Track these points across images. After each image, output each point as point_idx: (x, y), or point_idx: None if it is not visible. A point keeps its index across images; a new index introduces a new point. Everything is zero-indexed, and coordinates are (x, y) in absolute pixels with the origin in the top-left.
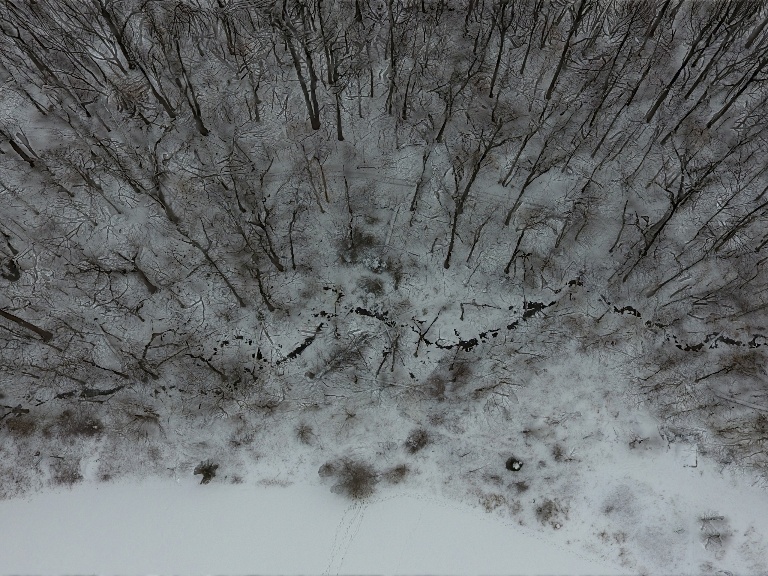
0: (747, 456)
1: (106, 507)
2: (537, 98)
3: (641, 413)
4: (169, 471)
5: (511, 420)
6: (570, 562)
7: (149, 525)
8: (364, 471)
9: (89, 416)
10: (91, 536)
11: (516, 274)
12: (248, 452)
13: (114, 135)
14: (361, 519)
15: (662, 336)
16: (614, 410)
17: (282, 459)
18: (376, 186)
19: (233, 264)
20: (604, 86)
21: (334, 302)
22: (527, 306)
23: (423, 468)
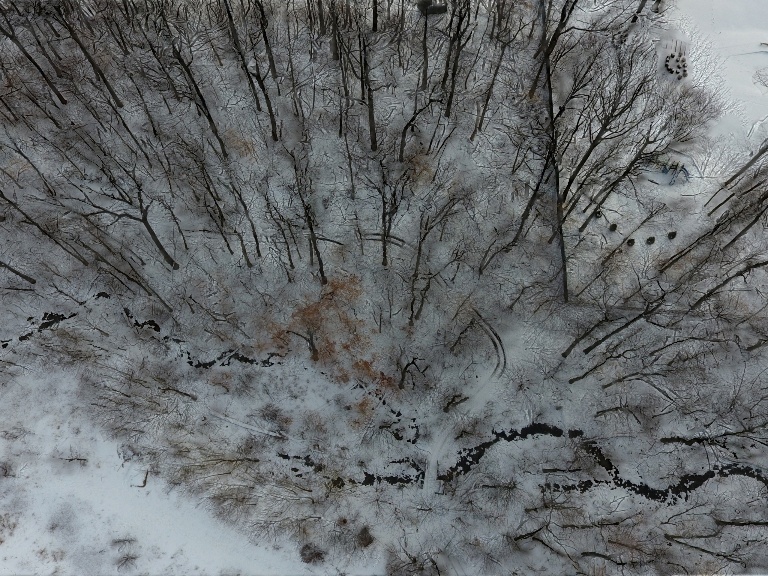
0: (203, 477)
1: None
2: None
3: None
4: None
5: None
6: None
7: None
8: None
9: None
10: None
11: (42, 284)
12: None
13: None
14: None
15: (175, 352)
16: (75, 426)
17: None
18: None
19: None
20: (176, 95)
21: None
22: (47, 317)
23: None
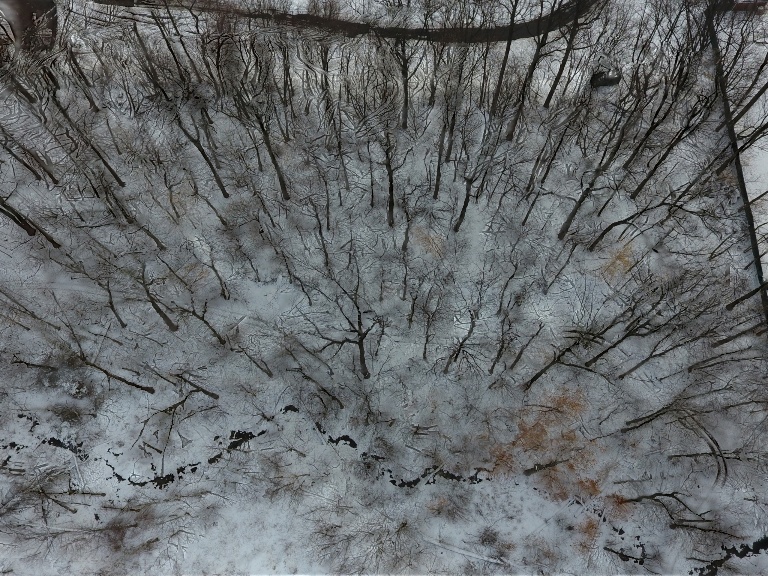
0: None
1: None
2: (274, 199)
3: (322, 569)
4: None
5: None
6: None
7: None
8: None
9: None
10: None
11: (226, 400)
12: None
13: None
14: None
15: (376, 470)
16: (292, 566)
17: None
18: None
19: None
20: (346, 186)
21: (27, 432)
22: (234, 436)
23: None
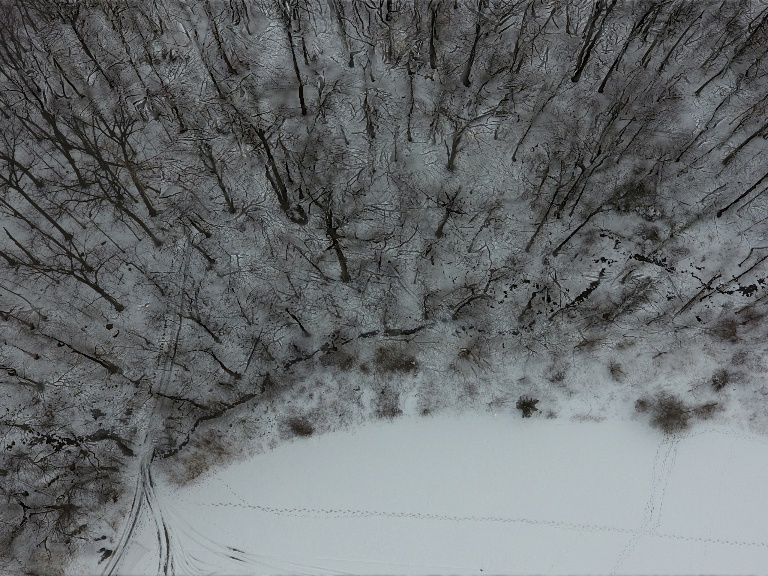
0: None
1: (428, 440)
2: None
3: None
4: (486, 406)
5: None
6: None
7: (473, 457)
8: (675, 407)
9: (403, 353)
10: (418, 467)
11: None
12: (561, 388)
13: (379, 85)
14: (675, 453)
15: None
16: None
17: (594, 395)
18: (640, 137)
19: (512, 211)
20: None
21: (612, 249)
22: None
23: (727, 405)
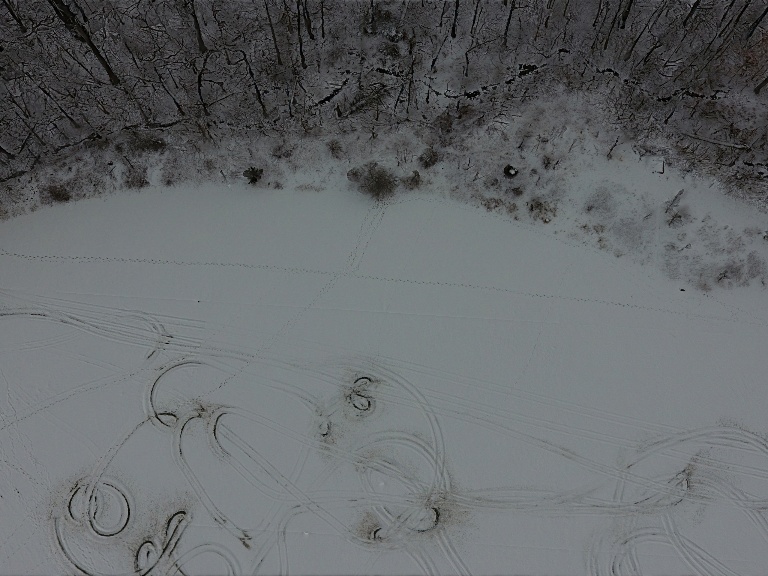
0: (706, 168)
1: (169, 205)
2: None
3: (617, 134)
4: (221, 178)
5: (508, 140)
6: (557, 247)
7: (206, 218)
8: (385, 178)
9: (154, 136)
10: (157, 225)
11: (513, 42)
12: (288, 164)
13: None
14: (383, 215)
15: (637, 90)
16: (595, 131)
17: (316, 170)
18: None
19: (271, 32)
20: None
21: (358, 64)
22: (522, 67)
23: (434, 180)
